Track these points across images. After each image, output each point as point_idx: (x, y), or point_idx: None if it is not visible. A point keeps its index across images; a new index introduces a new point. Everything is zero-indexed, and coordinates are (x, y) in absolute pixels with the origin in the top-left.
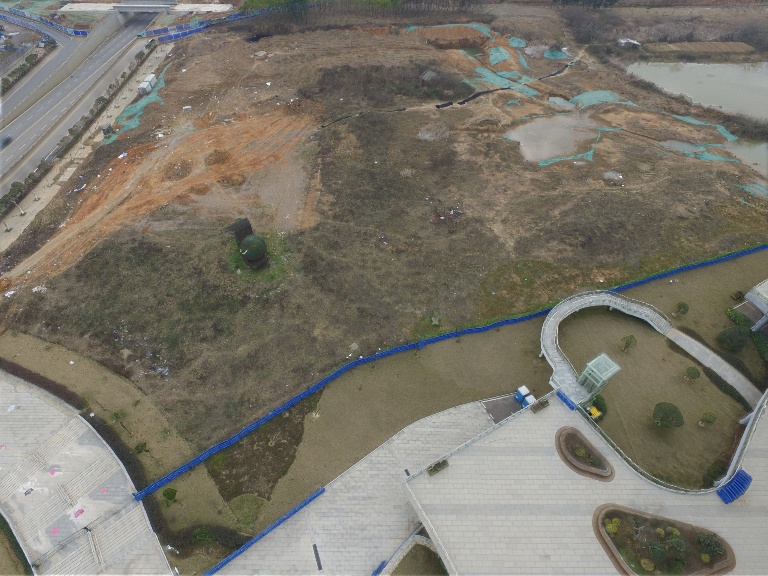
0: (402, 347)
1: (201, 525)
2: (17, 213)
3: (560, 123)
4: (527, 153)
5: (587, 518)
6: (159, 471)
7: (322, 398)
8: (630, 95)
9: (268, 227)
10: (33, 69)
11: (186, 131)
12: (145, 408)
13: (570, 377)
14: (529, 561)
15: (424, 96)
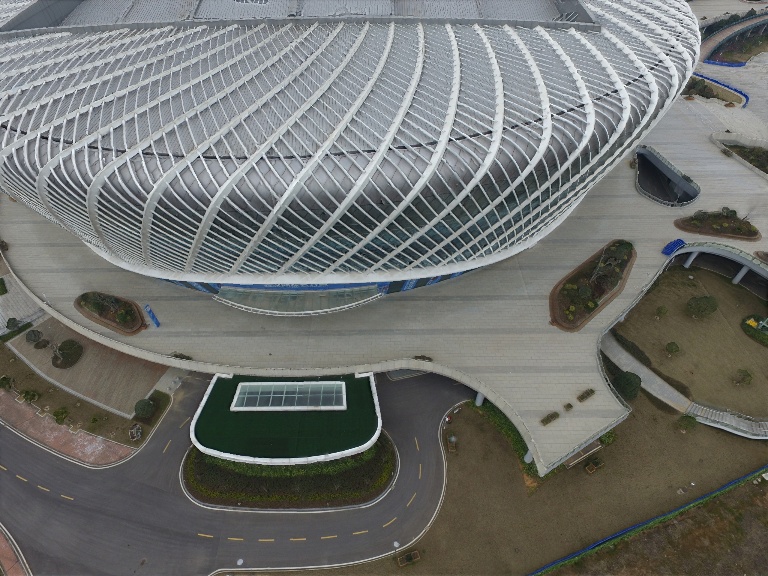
0: None
1: None
2: None
3: None
4: None
5: (765, 236)
6: None
7: None
8: None
9: None
10: None
11: None
12: None
13: None
14: None
15: None
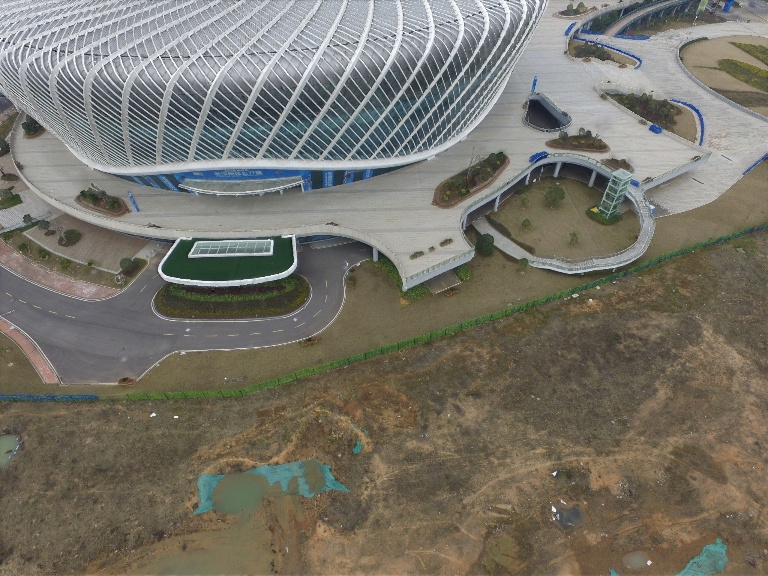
0: None
1: None
2: None
3: None
4: None
5: None
6: None
7: None
8: None
9: None
10: None
11: None
12: None
13: None
14: None
15: None
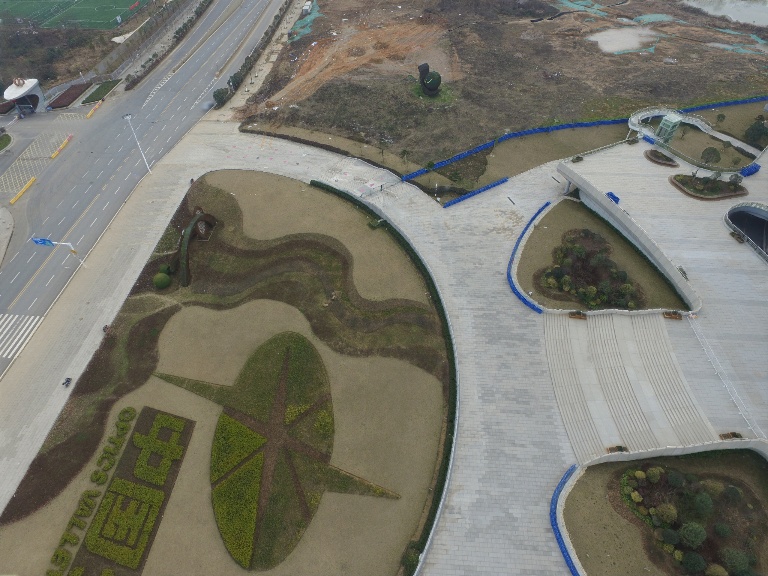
0: (539, 129)
1: (445, 186)
2: (252, 76)
3: (627, 32)
4: (604, 48)
5: (665, 178)
6: (408, 173)
7: (494, 150)
8: (681, 17)
9: None
10: (215, 0)
11: (352, 32)
12: (386, 154)
13: (650, 133)
14: (634, 189)
15: (521, 14)
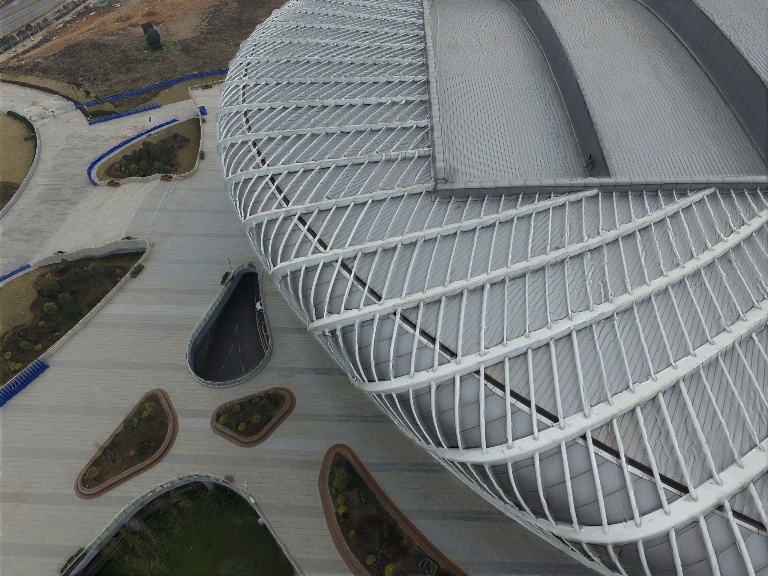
0: (218, 71)
1: (102, 110)
2: (29, 40)
3: None
4: None
5: None
6: None
7: (172, 87)
8: None
9: (169, 38)
10: None
11: (134, 4)
12: None
13: None
14: None
15: None
